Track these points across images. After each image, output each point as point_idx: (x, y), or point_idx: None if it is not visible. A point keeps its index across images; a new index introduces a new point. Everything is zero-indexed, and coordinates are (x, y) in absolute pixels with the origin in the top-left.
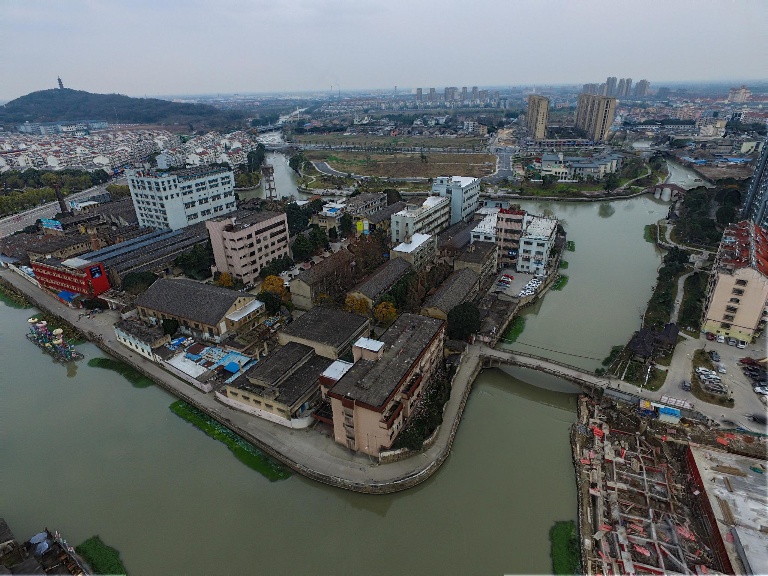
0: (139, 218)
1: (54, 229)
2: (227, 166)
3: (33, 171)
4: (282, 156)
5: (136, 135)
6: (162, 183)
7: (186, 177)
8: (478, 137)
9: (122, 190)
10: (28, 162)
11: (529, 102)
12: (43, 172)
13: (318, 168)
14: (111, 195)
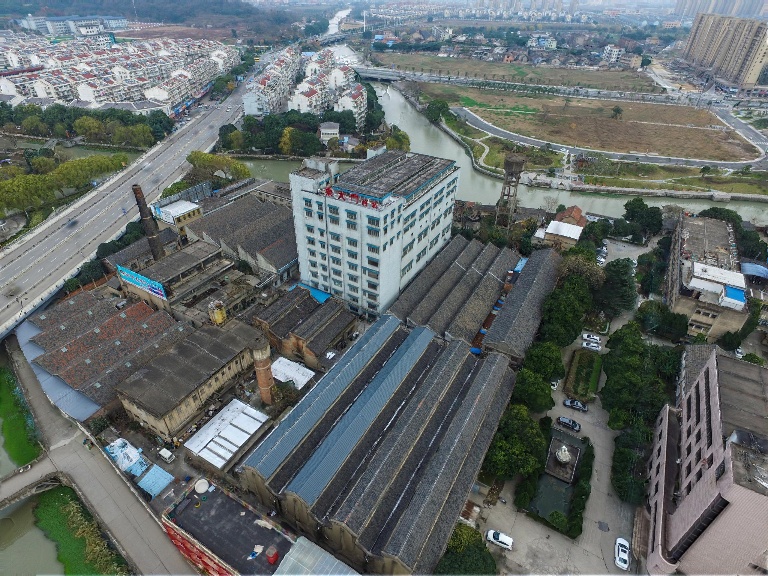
0: (303, 266)
1: (146, 290)
2: (352, 117)
3: (59, 109)
4: (400, 94)
5: (183, 47)
6: (383, 219)
7: (410, 194)
8: (629, 72)
9: (216, 164)
10: (49, 91)
11: (697, 23)
12: (75, 112)
13: (467, 121)
14: (195, 169)
